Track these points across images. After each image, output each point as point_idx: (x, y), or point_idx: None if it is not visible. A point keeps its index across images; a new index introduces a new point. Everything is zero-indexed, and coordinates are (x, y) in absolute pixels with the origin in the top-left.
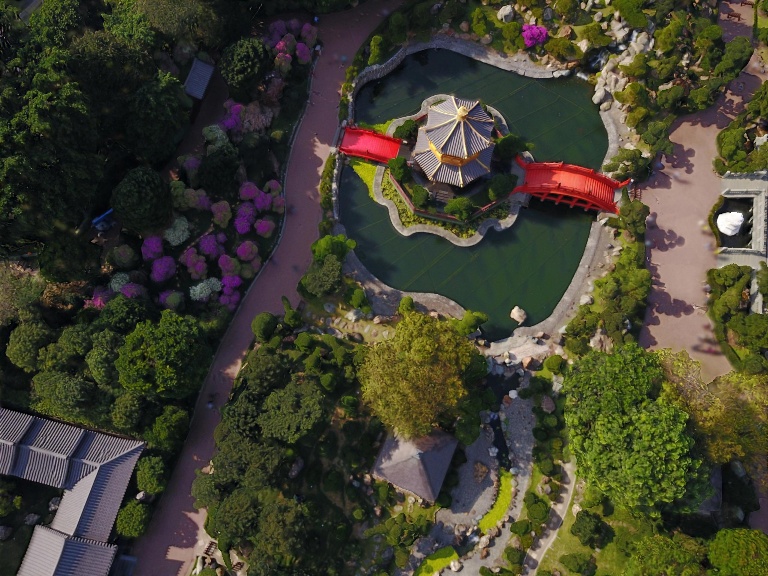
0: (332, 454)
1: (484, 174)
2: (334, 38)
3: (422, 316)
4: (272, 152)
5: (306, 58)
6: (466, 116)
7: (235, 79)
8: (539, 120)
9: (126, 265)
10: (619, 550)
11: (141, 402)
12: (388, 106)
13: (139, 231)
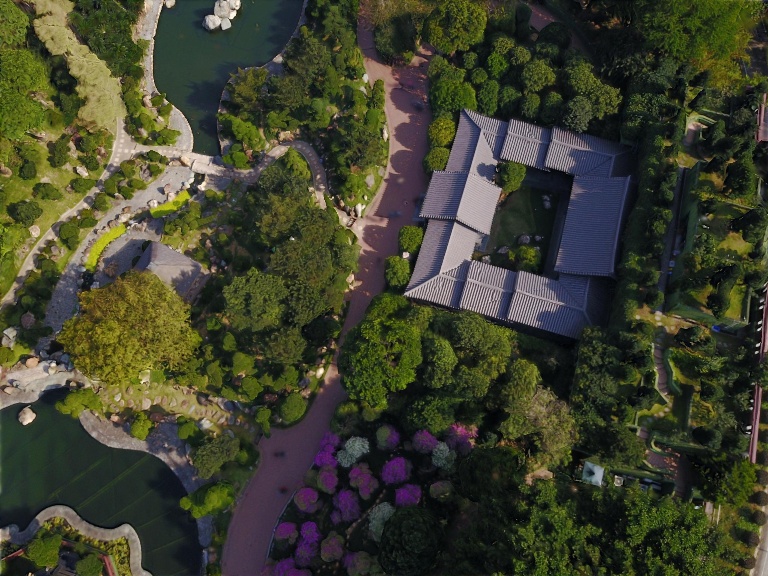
0: None
1: None
2: None
3: (104, 377)
4: None
5: None
6: None
7: None
8: None
9: None
10: (6, 193)
11: None
12: None
13: None
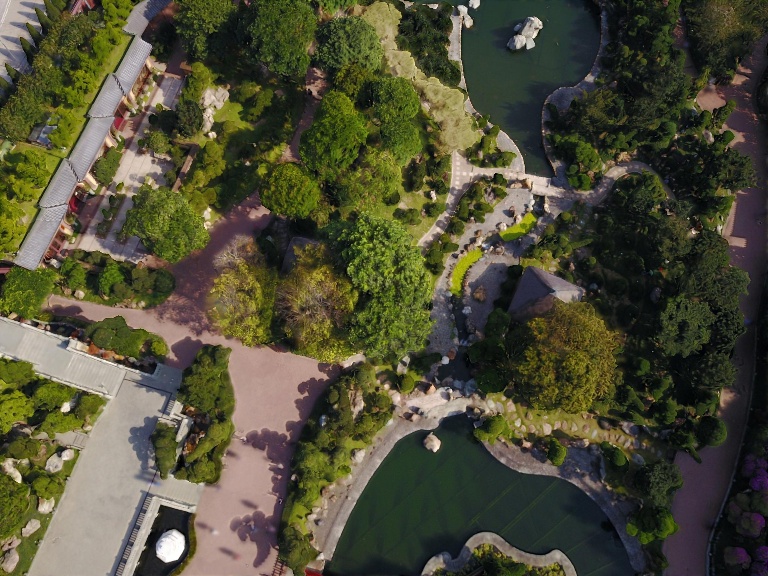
0: None
1: None
2: None
3: None
4: None
5: None
6: None
7: None
8: None
9: None
10: None
11: None
12: None
13: None
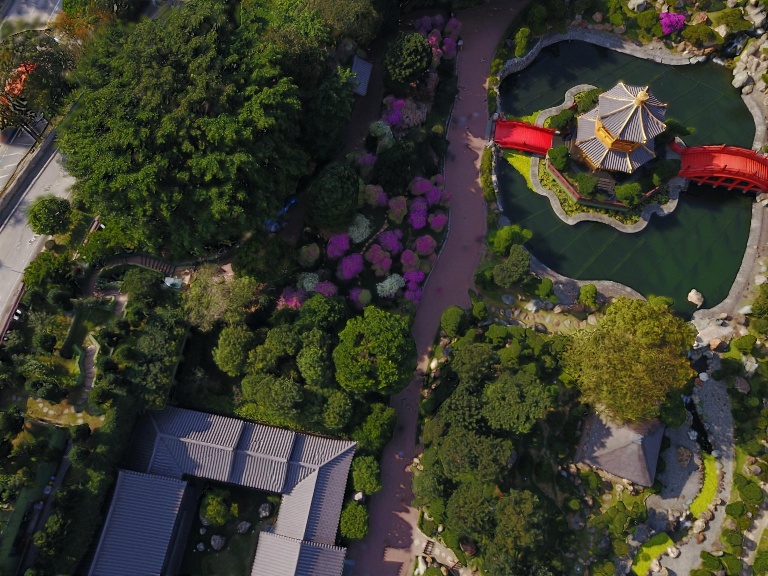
0: (540, 445)
1: (650, 159)
2: (471, 33)
3: None
4: (431, 147)
5: (453, 53)
6: (643, 101)
7: (402, 74)
8: (682, 106)
9: (310, 264)
10: None
11: (352, 401)
12: (531, 98)
13: (327, 229)
